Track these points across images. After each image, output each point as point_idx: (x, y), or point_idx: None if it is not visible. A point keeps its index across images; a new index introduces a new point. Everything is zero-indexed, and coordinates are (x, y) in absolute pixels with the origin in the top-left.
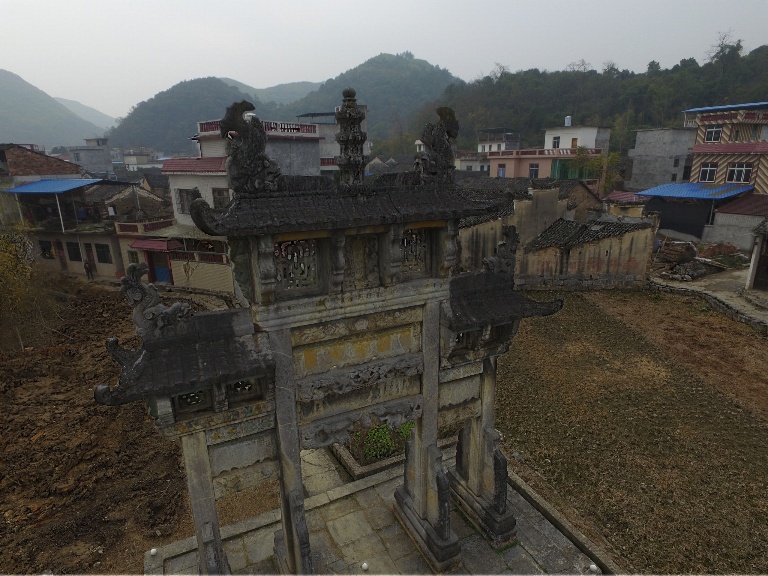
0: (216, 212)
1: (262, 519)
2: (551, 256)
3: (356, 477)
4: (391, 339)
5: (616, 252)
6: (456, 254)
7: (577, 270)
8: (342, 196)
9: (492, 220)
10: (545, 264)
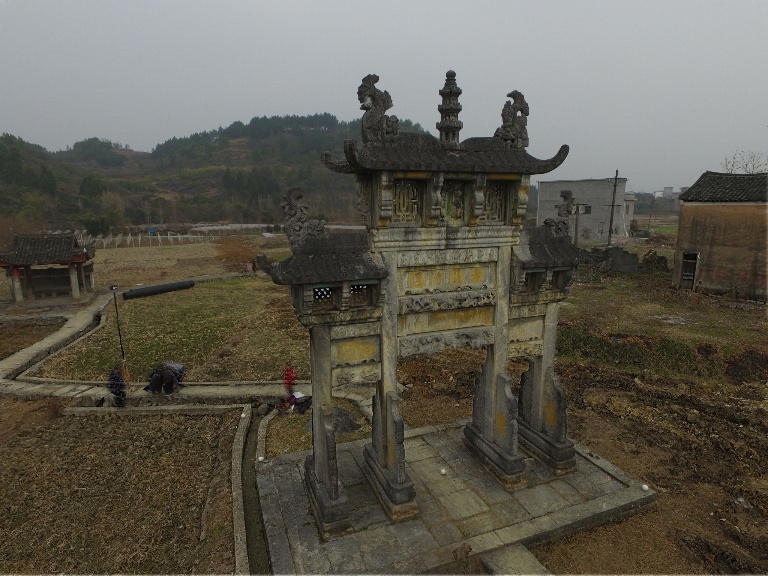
0: None
1: (565, 516)
2: None
3: None
4: None
5: None
6: None
7: None
8: None
9: None
10: None
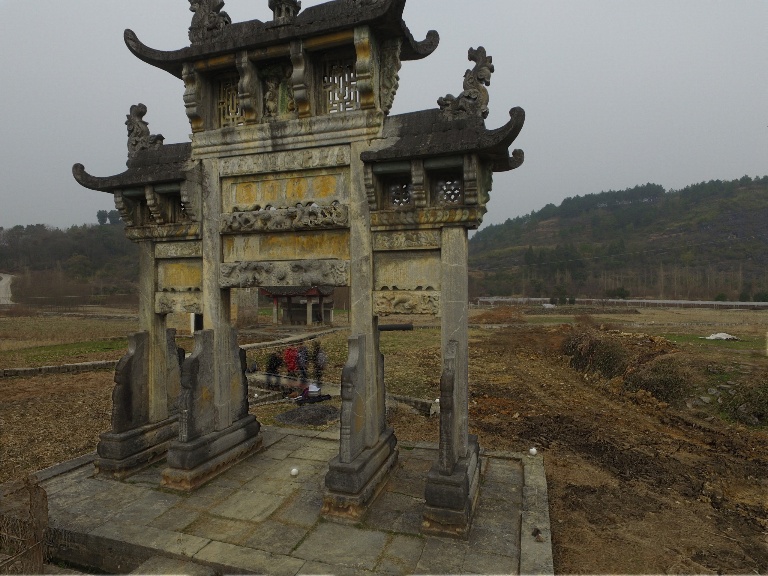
0: None
1: (322, 573)
2: None
3: None
4: None
5: None
6: None
7: None
8: None
9: None
10: None
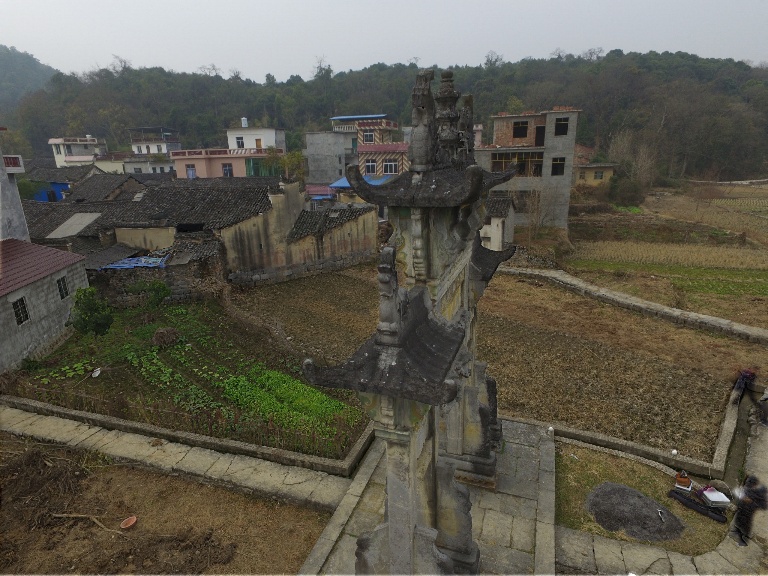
0: (380, 189)
1: (321, 549)
2: (309, 244)
3: (347, 471)
4: (455, 299)
5: (355, 233)
6: (222, 256)
7: (330, 253)
8: (456, 169)
9: (253, 216)
10: (305, 252)
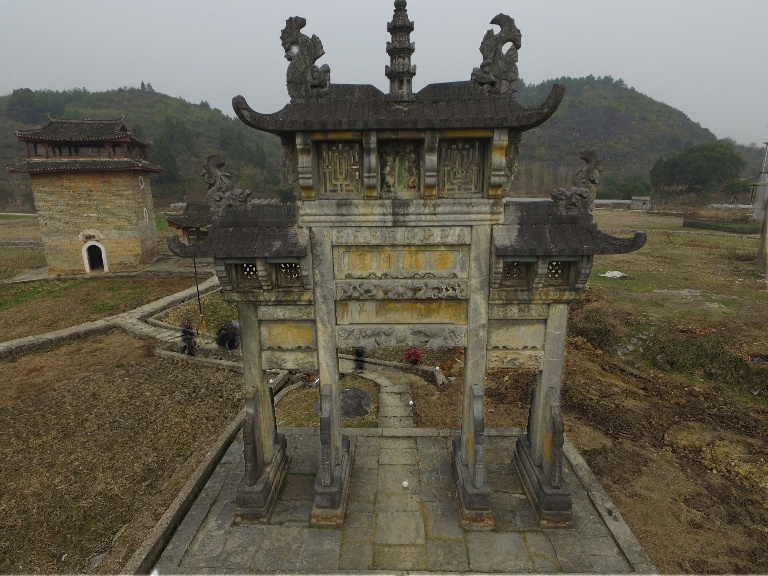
0: None
1: None
2: None
3: None
4: None
5: None
6: None
7: None
8: None
9: None
10: None
